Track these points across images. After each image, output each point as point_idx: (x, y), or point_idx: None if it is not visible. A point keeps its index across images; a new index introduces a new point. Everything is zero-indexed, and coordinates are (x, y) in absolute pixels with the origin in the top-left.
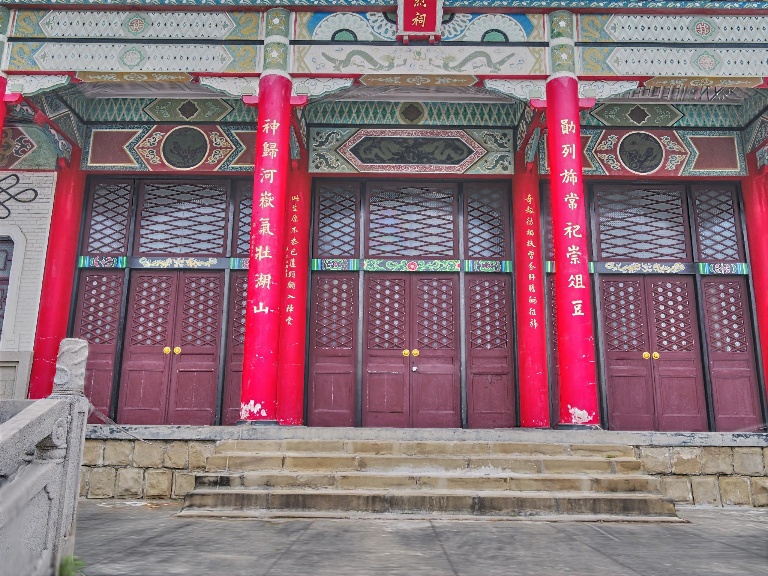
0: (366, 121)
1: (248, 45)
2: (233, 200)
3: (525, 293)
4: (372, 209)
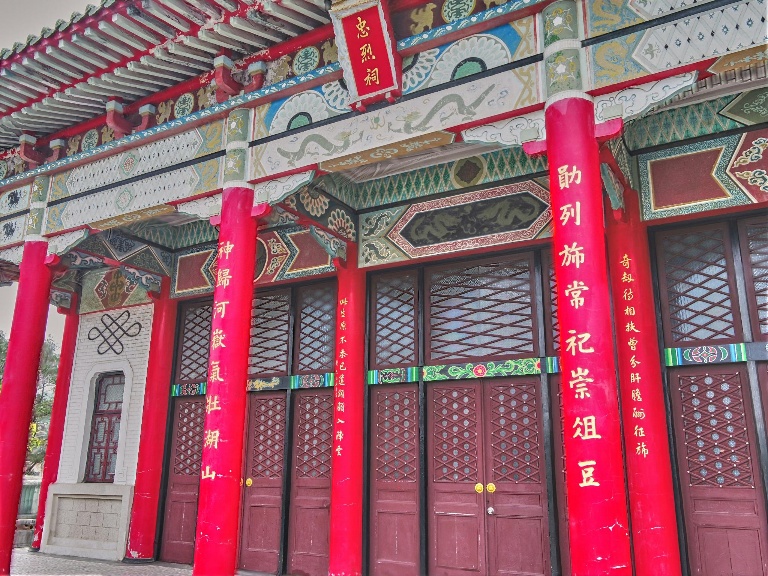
0: (417, 194)
1: (212, 159)
2: (293, 310)
3: (627, 403)
4: (433, 301)
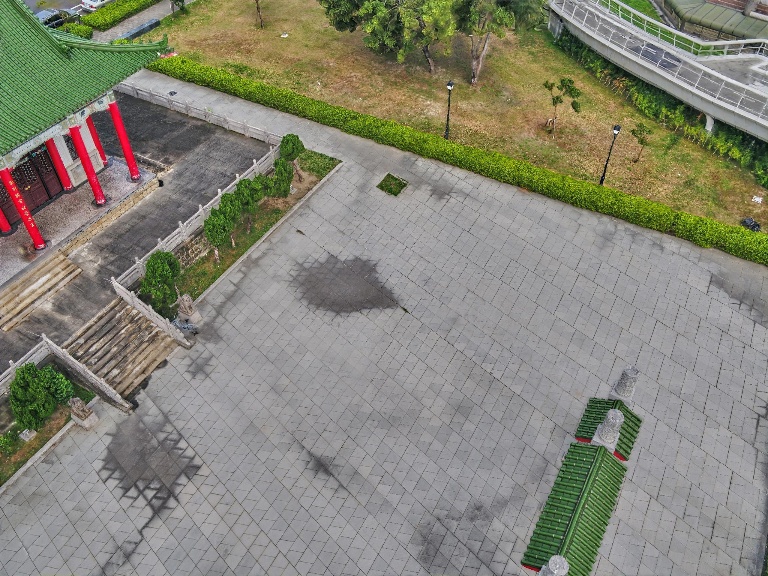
0: None
1: None
2: None
3: None
4: None
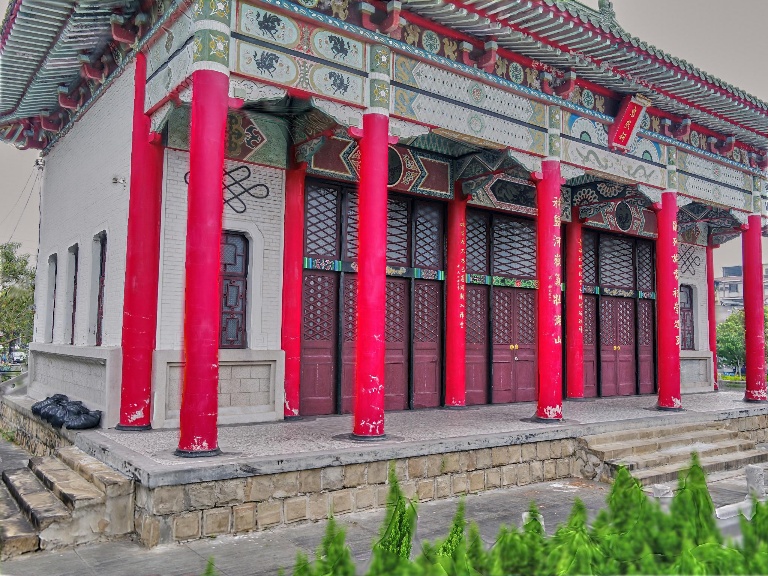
0: None
1: (540, 131)
2: None
3: (577, 308)
4: (495, 236)
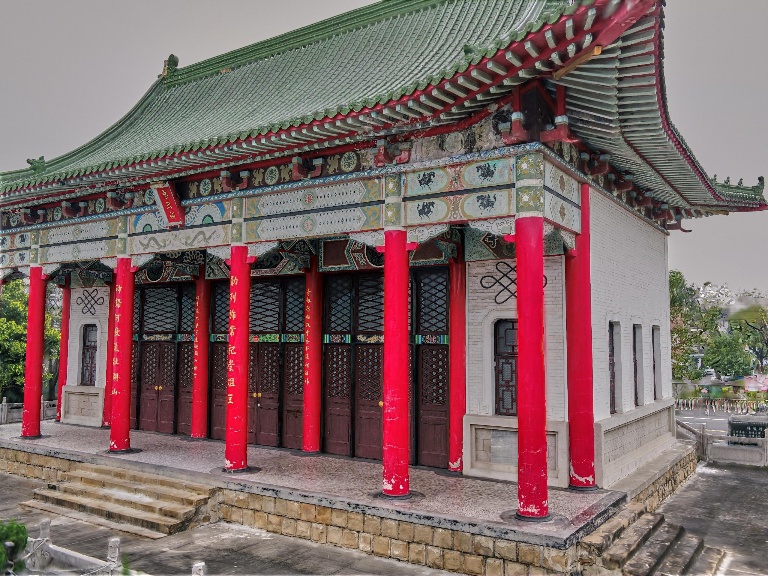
0: None
1: (113, 239)
2: (178, 298)
3: None
4: None
